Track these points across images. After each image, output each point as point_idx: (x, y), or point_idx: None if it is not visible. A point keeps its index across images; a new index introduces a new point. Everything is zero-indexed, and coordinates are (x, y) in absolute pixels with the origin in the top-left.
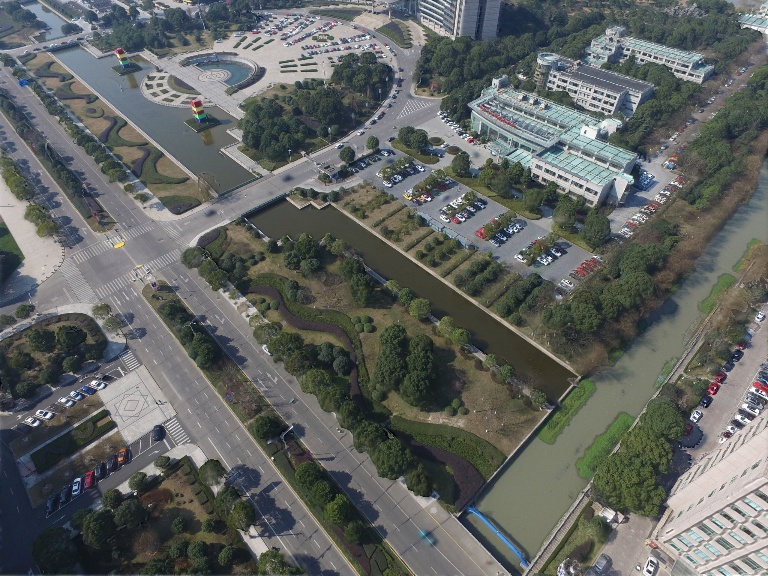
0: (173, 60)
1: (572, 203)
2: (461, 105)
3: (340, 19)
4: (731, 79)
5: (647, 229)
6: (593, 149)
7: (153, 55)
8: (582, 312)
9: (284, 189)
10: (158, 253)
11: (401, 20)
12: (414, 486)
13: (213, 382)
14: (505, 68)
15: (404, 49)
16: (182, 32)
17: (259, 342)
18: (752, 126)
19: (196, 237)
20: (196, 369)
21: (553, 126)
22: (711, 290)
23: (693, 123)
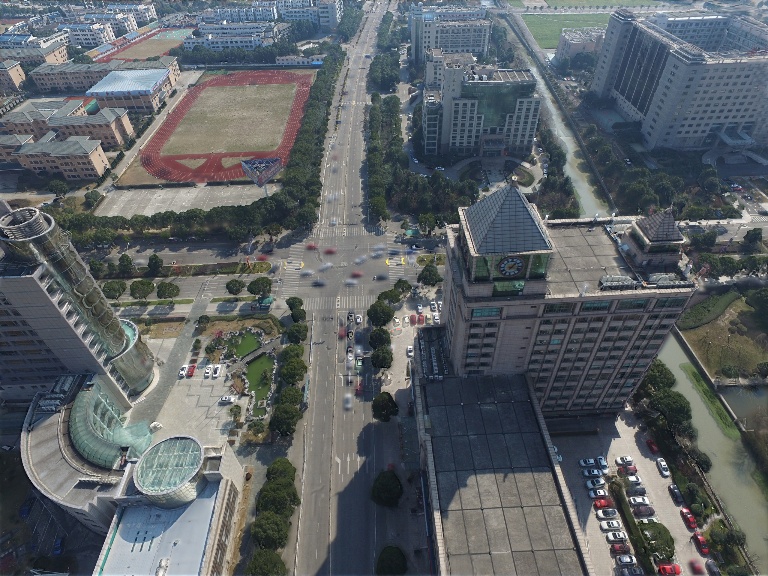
0: None
1: None
2: None
3: None
4: None
5: None
6: None
7: None
8: None
9: None
10: None
11: None
12: None
13: None
14: None
15: None
16: None
17: None
18: None
19: None
20: None
21: None
22: None
23: None
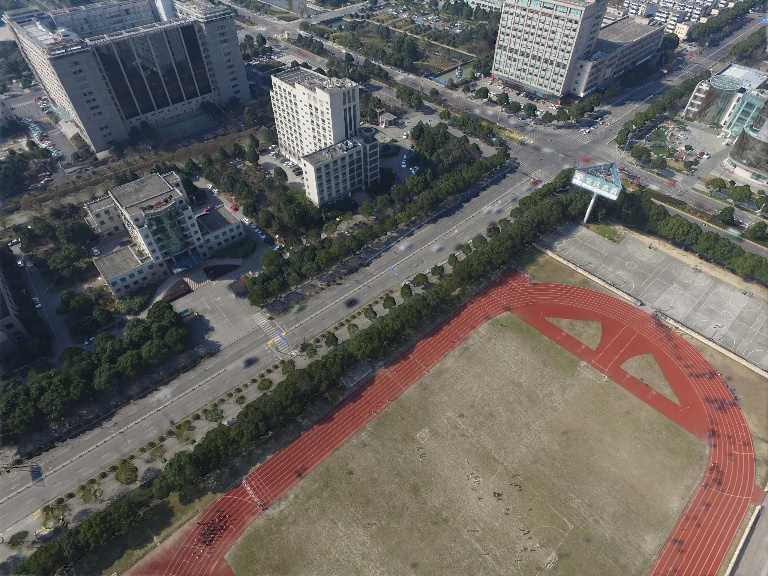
0: None
1: None
2: None
3: None
4: None
5: None
6: None
7: None
8: (478, 29)
9: None
10: None
11: None
12: (407, 63)
13: (323, 57)
14: None
15: None
16: None
17: (341, 44)
18: None
19: None
20: (314, 55)
21: None
22: None
23: None
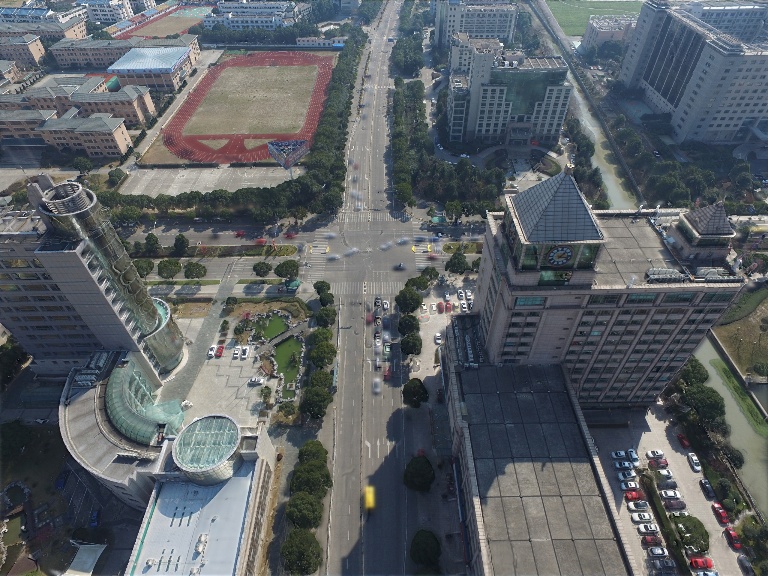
0: None
1: None
2: None
3: None
4: None
5: None
6: None
7: None
8: None
9: None
10: None
11: None
12: None
13: None
14: None
15: None
16: None
17: None
18: None
19: None
20: None
21: None
22: None
23: None
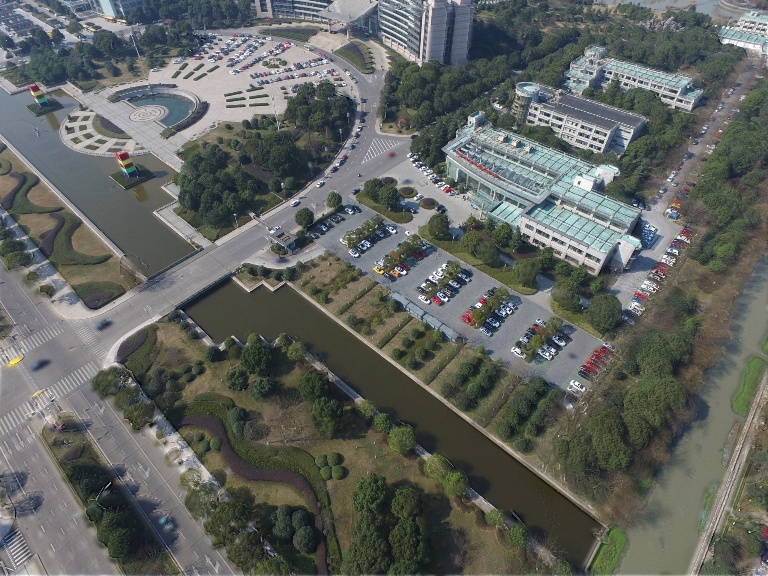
0: (100, 95)
1: (572, 275)
2: (434, 147)
3: (293, 40)
4: (720, 103)
5: (661, 305)
6: (590, 205)
7: (77, 89)
8: (607, 449)
9: (229, 266)
10: (67, 369)
11: (361, 40)
12: None
13: None
14: (479, 97)
15: (366, 75)
16: (112, 60)
17: (193, 514)
18: (756, 164)
19: (117, 342)
20: None
21: (540, 173)
22: (743, 382)
23: (690, 159)
